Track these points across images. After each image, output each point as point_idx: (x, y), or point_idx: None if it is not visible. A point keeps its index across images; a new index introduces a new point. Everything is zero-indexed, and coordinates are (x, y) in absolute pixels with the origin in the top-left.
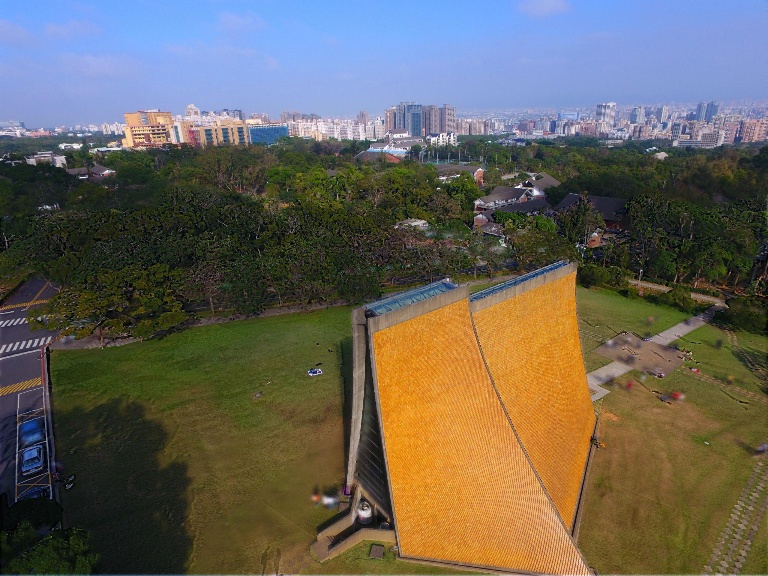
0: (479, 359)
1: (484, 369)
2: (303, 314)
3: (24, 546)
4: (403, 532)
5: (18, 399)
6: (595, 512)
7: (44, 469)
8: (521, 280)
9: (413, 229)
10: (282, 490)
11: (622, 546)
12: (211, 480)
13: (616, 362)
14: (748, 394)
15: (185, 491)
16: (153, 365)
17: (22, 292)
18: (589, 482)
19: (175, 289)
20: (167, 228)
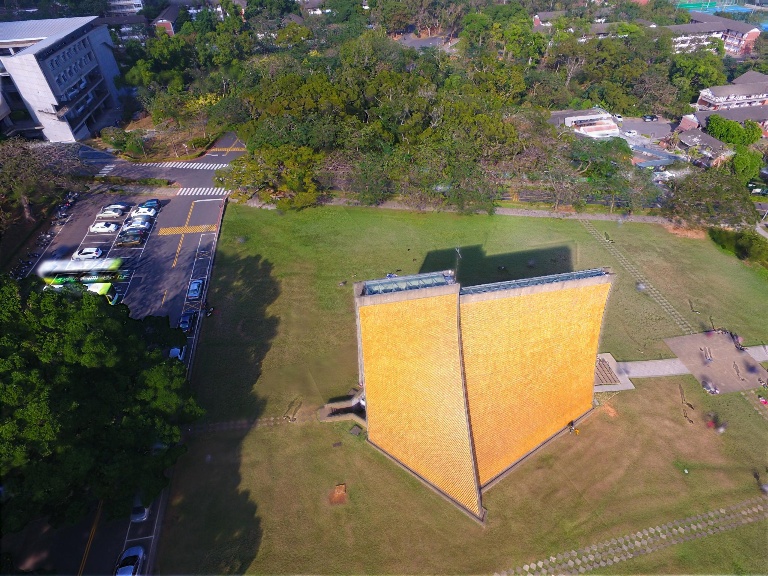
0: (455, 341)
1: (457, 350)
2: (414, 213)
3: (156, 361)
4: (371, 428)
5: (200, 239)
6: (521, 476)
7: (199, 298)
8: (537, 281)
9: (567, 138)
10: (323, 364)
11: (521, 507)
12: (285, 340)
13: (678, 360)
14: None
15: (267, 342)
16: (285, 234)
17: (228, 135)
18: (537, 454)
19: (314, 172)
20: (322, 110)
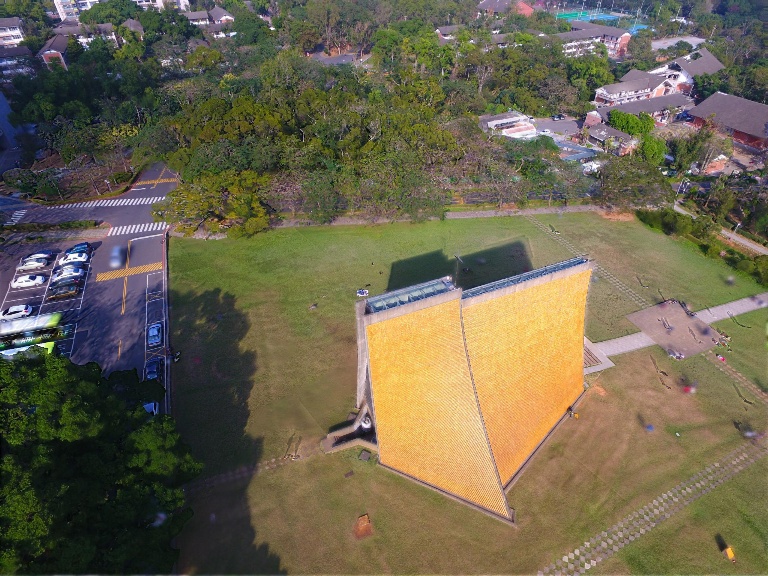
0: (461, 346)
1: (464, 355)
2: (369, 227)
3: (140, 420)
4: (382, 450)
5: (147, 279)
6: (538, 469)
7: (162, 344)
8: (527, 276)
9: (498, 140)
10: (313, 393)
11: (545, 500)
12: (267, 374)
13: (643, 333)
14: (760, 395)
15: (248, 379)
16: (240, 263)
17: (152, 166)
18: (546, 444)
19: (261, 196)
20: (259, 131)
